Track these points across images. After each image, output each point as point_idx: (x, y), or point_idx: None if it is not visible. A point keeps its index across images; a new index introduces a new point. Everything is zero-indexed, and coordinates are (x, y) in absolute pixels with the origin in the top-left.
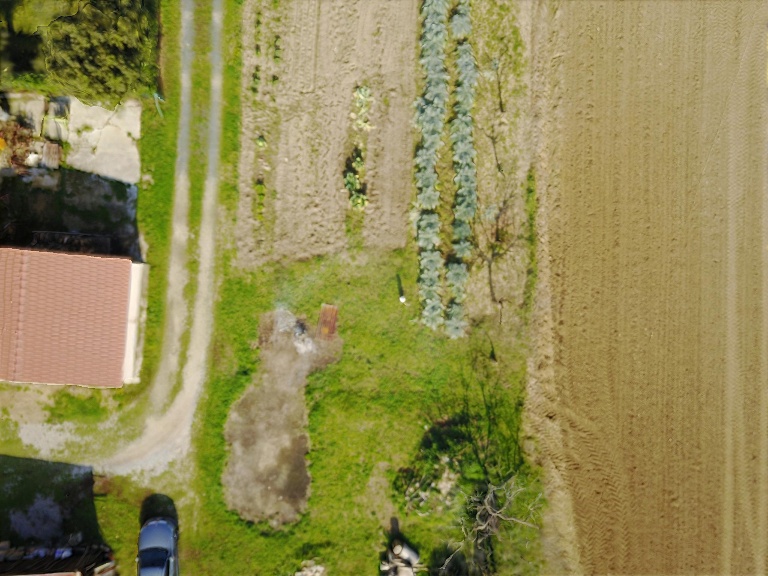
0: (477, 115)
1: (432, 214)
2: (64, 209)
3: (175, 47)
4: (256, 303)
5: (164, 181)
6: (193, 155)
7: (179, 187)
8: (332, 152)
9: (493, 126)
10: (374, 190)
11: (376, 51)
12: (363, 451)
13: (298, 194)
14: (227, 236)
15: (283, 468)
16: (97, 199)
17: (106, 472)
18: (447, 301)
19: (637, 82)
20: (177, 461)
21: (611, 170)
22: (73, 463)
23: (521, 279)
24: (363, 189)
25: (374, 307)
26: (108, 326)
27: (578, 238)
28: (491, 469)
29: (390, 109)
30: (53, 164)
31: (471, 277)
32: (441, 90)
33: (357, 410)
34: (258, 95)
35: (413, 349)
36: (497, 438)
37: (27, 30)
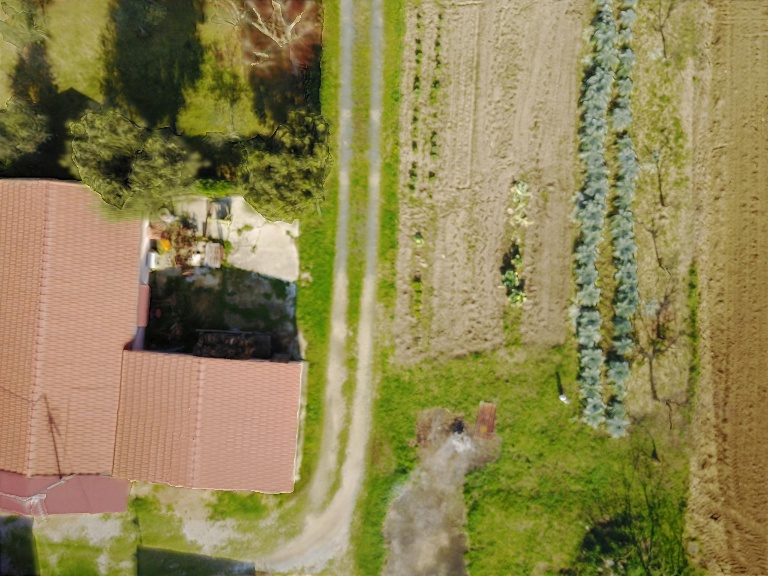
0: (637, 209)
1: (593, 312)
2: (225, 307)
3: (332, 145)
4: (414, 400)
5: (322, 279)
6: (351, 252)
7: (337, 284)
8: (489, 248)
9: (653, 220)
10: (532, 286)
11: (533, 146)
12: (523, 551)
13: (455, 290)
14: (385, 333)
15: (442, 567)
16: (257, 297)
17: (268, 568)
18: (607, 399)
19: None
20: (338, 558)
21: None
22: (236, 559)
23: (683, 376)
24: (521, 285)
25: (533, 405)
26: (280, 431)
27: (743, 335)
28: (655, 572)
29: (548, 204)
30: (215, 263)
31: (632, 374)
32: (601, 186)
33: (517, 510)
34: (415, 192)
35: (573, 448)
36: (660, 539)
37: (189, 131)
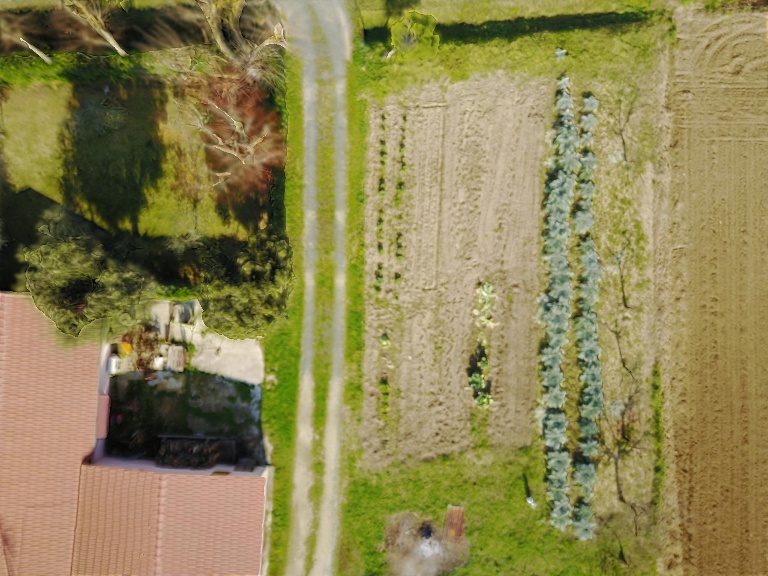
0: (600, 310)
1: (559, 414)
2: (188, 411)
3: (298, 246)
4: (382, 505)
5: (288, 381)
6: (317, 355)
7: (303, 387)
8: (455, 349)
9: (616, 320)
10: (498, 387)
11: (498, 247)
12: None
13: (422, 392)
14: (351, 436)
15: None
16: (221, 400)
17: None
18: (574, 500)
19: (761, 276)
20: None
21: (737, 365)
22: None
23: (648, 476)
24: (487, 386)
25: (501, 508)
26: (243, 546)
27: (705, 434)
28: None
29: (513, 305)
30: (178, 367)
31: (598, 475)
32: (565, 288)
33: None
34: (381, 293)
35: (541, 550)
36: None
37: (151, 232)
